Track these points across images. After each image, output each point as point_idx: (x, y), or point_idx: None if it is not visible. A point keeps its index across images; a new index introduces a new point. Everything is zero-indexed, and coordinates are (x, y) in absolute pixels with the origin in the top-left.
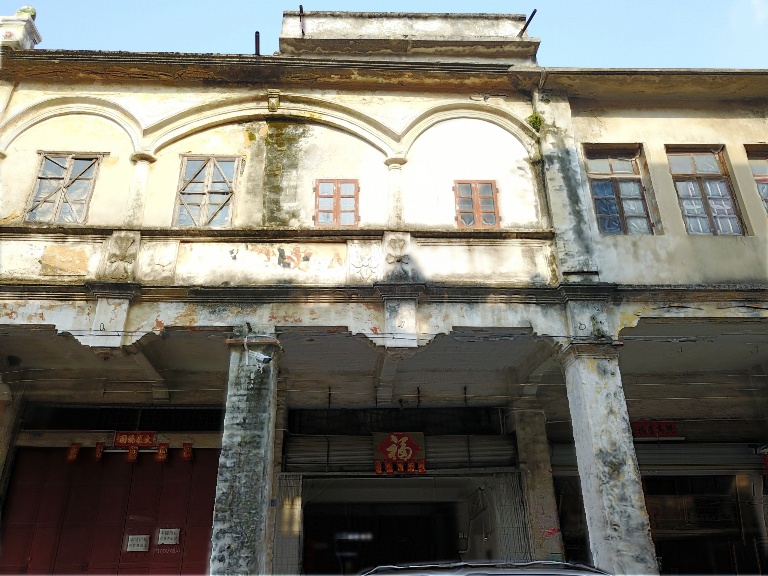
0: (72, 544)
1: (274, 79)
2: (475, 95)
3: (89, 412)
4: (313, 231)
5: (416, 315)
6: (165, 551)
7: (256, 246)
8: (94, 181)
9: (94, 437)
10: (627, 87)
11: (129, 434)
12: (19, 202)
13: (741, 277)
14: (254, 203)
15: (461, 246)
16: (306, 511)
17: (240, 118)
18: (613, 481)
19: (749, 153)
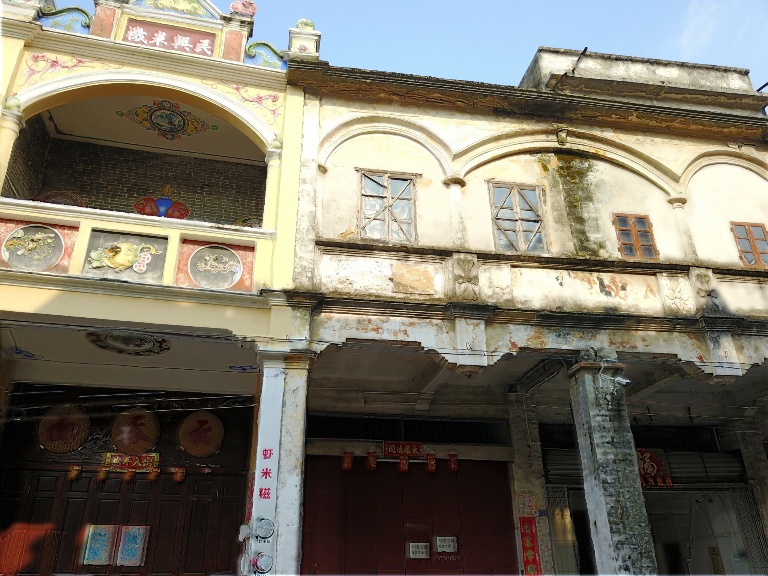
0: (358, 551)
1: (558, 114)
2: (731, 143)
3: (354, 421)
4: (628, 263)
5: None
6: (445, 558)
7: (577, 274)
8: (414, 201)
9: (364, 446)
10: None
11: (397, 444)
12: (351, 218)
13: None
14: (564, 232)
15: (754, 284)
16: None
17: (532, 149)
18: None
19: None
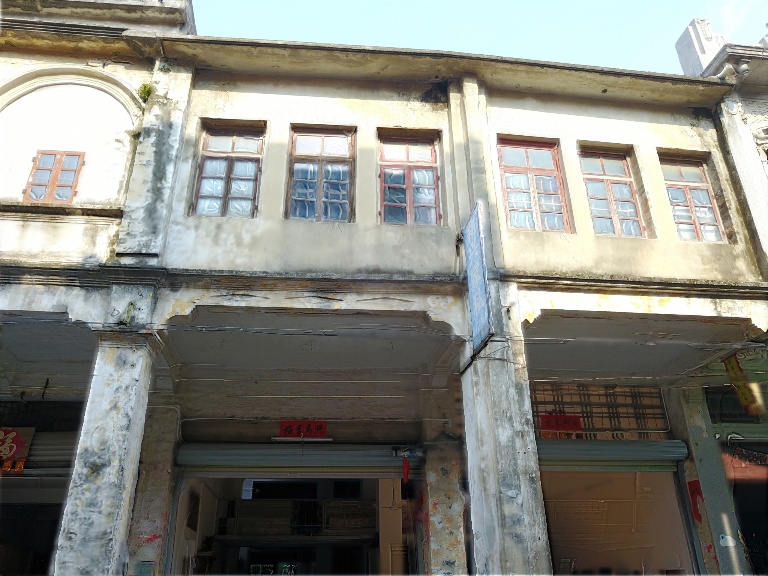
0: None
1: None
2: (93, 61)
3: None
4: None
5: None
6: None
7: None
8: None
9: None
10: (258, 60)
11: None
12: None
13: (325, 266)
14: None
15: (14, 221)
16: None
17: None
18: (88, 484)
19: (388, 137)
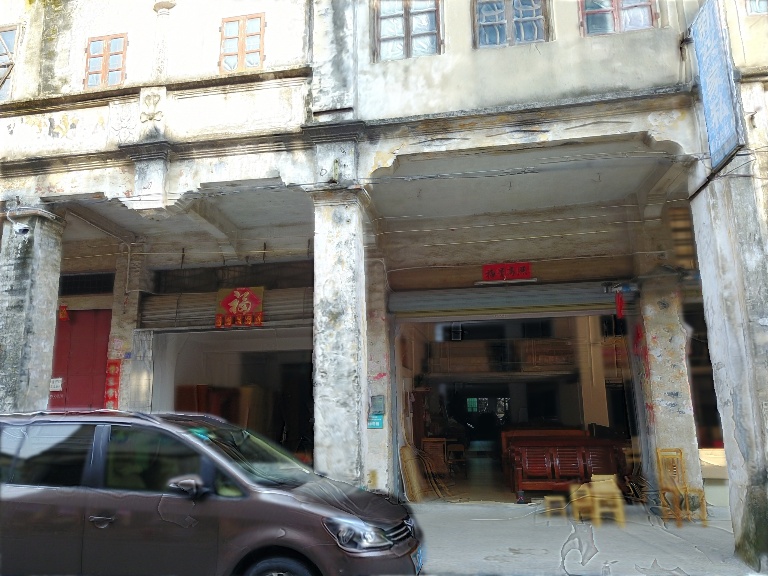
0: None
1: None
2: None
3: None
4: (76, 96)
5: (166, 175)
6: (52, 397)
7: (30, 118)
8: None
9: None
10: None
11: None
12: None
13: (526, 95)
14: (31, 73)
15: (217, 95)
16: (178, 361)
17: None
18: (328, 330)
19: None
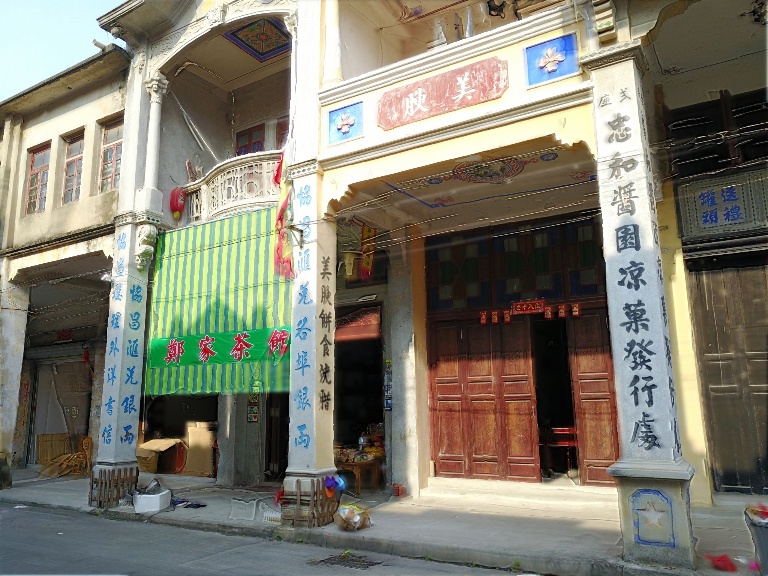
0: None
1: None
2: None
3: None
4: None
5: None
6: None
7: None
8: None
9: None
10: None
11: None
12: None
13: None
14: None
15: None
16: None
17: None
18: None
19: None
